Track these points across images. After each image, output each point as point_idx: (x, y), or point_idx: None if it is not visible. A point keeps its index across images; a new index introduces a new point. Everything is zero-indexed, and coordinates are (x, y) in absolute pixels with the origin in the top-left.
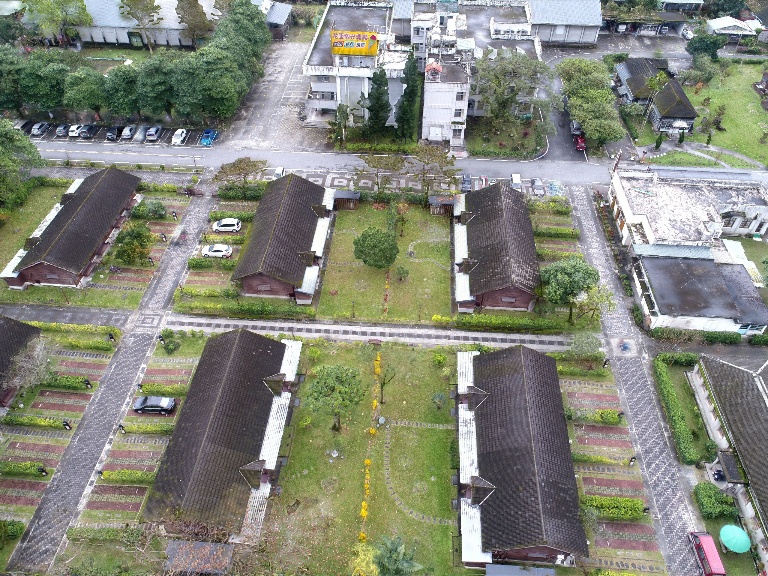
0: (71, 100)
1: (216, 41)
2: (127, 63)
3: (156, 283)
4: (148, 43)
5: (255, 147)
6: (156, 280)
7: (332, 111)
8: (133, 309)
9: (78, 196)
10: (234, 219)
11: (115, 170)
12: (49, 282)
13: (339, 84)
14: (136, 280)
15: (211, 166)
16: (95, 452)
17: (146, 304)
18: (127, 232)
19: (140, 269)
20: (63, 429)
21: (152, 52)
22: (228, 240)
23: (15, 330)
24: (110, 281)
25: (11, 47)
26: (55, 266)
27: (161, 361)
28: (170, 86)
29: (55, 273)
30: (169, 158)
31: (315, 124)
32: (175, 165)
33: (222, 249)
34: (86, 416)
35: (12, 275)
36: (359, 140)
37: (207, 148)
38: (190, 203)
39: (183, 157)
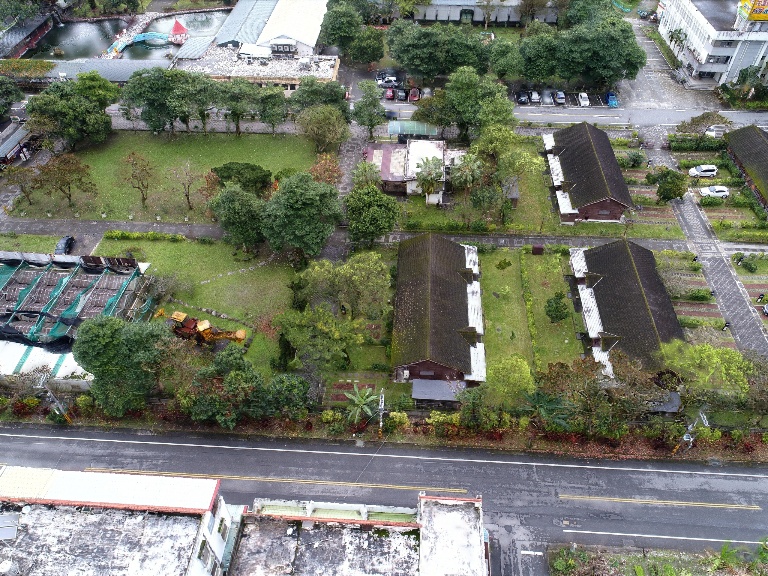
0: (506, 66)
1: (602, 13)
2: (493, 36)
3: (683, 218)
4: (488, 19)
5: (659, 107)
6: (680, 216)
7: (706, 75)
8: (684, 239)
9: (573, 147)
10: (712, 165)
11: (589, 125)
12: (596, 218)
13: (738, 48)
14: (663, 216)
15: (635, 124)
16: (764, 346)
17: (691, 235)
18: (662, 173)
19: (658, 208)
20: (719, 330)
21: (486, 28)
22: (718, 183)
23: (641, 251)
24: (642, 217)
25: (365, 25)
26: (618, 202)
27: (750, 278)
28: (593, 52)
29: (610, 209)
30: (591, 118)
31: (698, 87)
32: (602, 123)
33: (724, 189)
34: (728, 320)
35: (575, 211)
36: (750, 100)
37: (616, 109)
38: (647, 154)
39: (603, 117)
